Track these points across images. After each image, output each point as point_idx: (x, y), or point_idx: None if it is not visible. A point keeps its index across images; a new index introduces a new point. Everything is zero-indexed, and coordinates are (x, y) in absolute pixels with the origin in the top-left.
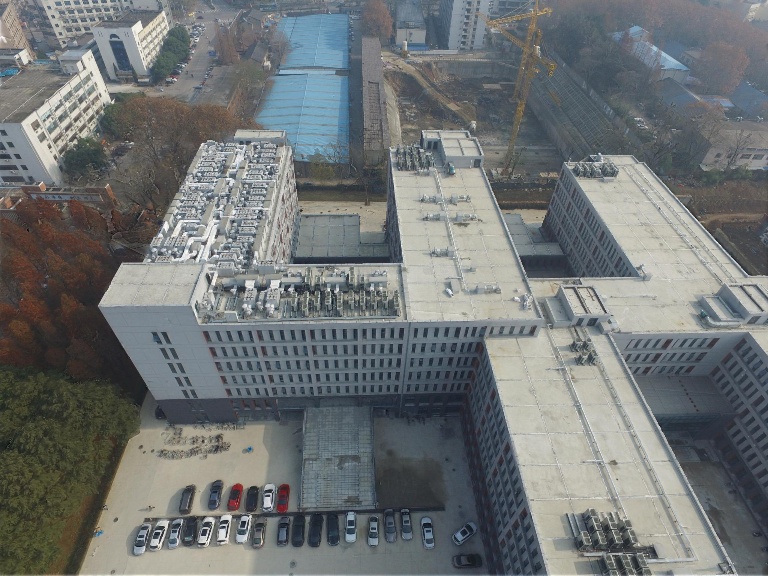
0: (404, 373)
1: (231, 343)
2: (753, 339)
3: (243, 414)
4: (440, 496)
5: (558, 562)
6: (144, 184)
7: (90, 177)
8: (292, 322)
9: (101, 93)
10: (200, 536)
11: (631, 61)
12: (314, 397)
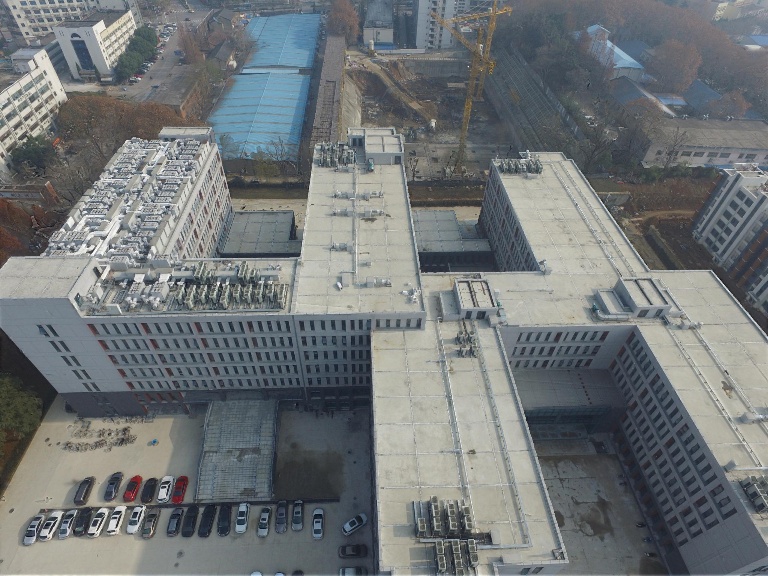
0: (301, 366)
1: (119, 336)
2: (639, 332)
3: (153, 407)
4: (337, 488)
5: (394, 548)
6: (75, 181)
7: (27, 174)
8: (175, 315)
9: (56, 92)
10: (90, 526)
11: (587, 60)
12: (217, 390)
